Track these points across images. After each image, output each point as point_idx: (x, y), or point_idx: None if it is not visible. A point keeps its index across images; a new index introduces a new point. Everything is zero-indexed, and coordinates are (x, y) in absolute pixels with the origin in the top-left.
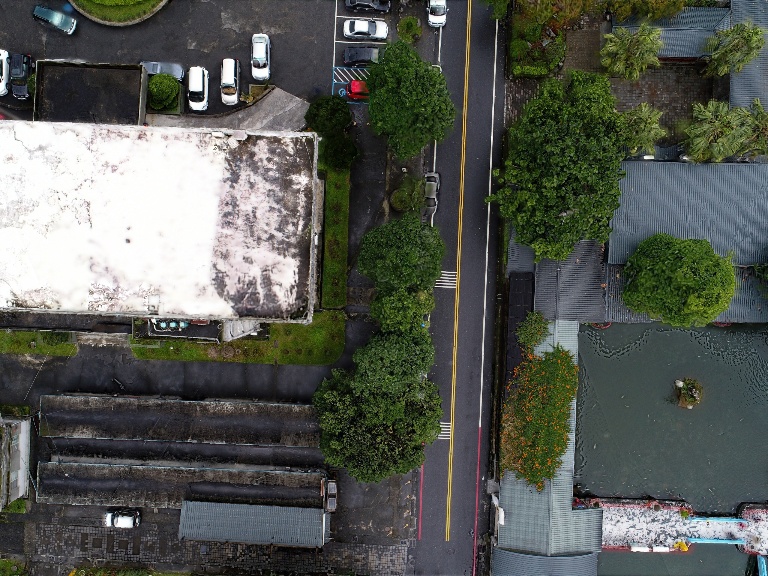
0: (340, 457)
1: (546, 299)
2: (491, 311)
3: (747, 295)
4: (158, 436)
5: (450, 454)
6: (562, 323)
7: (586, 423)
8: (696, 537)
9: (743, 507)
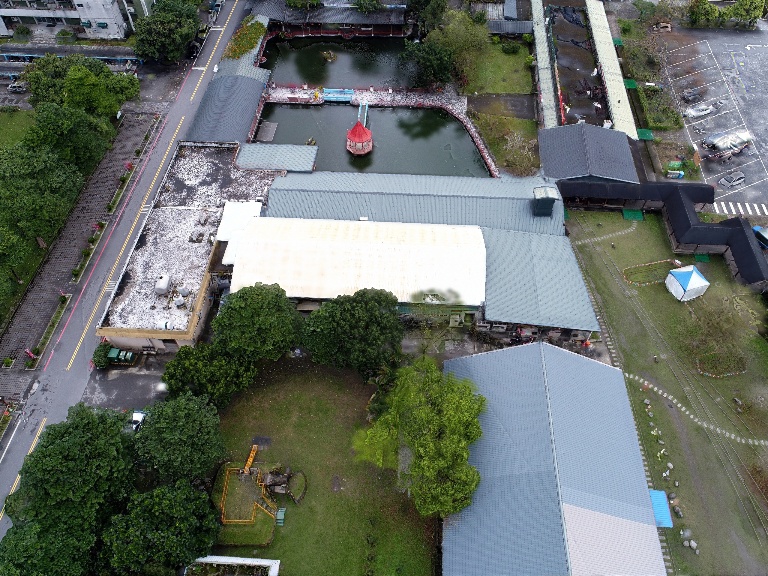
0: (139, 38)
1: (256, 11)
2: None
3: (350, 15)
4: None
5: (203, 74)
6: (261, 16)
7: (278, 70)
8: None
9: None
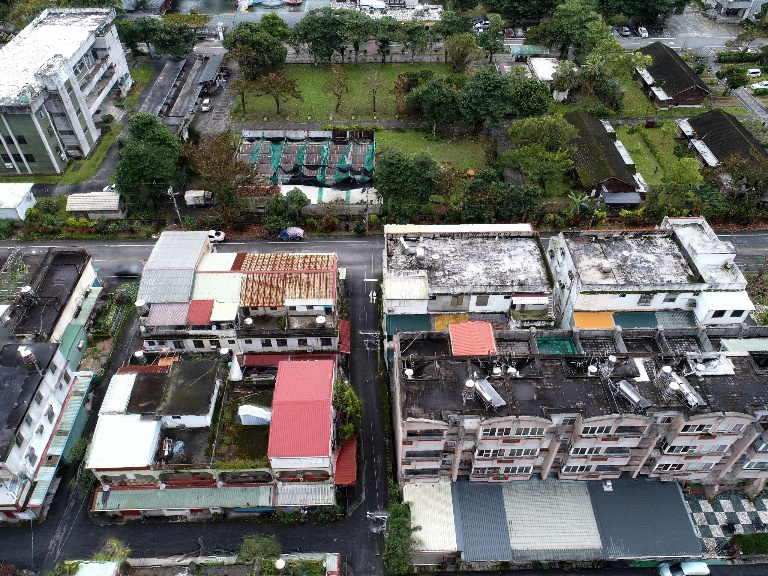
0: None
1: None
2: None
3: None
4: None
5: None
6: None
7: None
8: None
9: (236, 5)
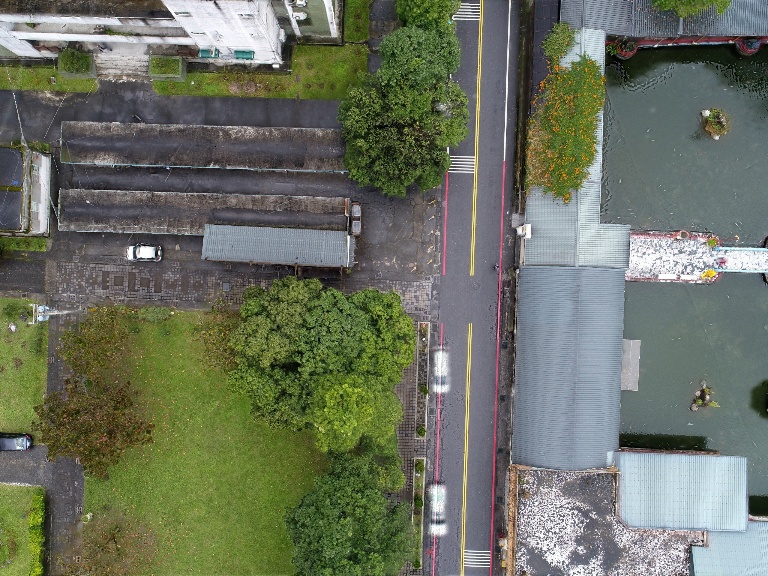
0: (366, 160)
1: (572, 8)
2: (515, 43)
3: None
4: (180, 162)
5: (474, 188)
6: (589, 32)
7: (611, 159)
8: (723, 268)
9: None
